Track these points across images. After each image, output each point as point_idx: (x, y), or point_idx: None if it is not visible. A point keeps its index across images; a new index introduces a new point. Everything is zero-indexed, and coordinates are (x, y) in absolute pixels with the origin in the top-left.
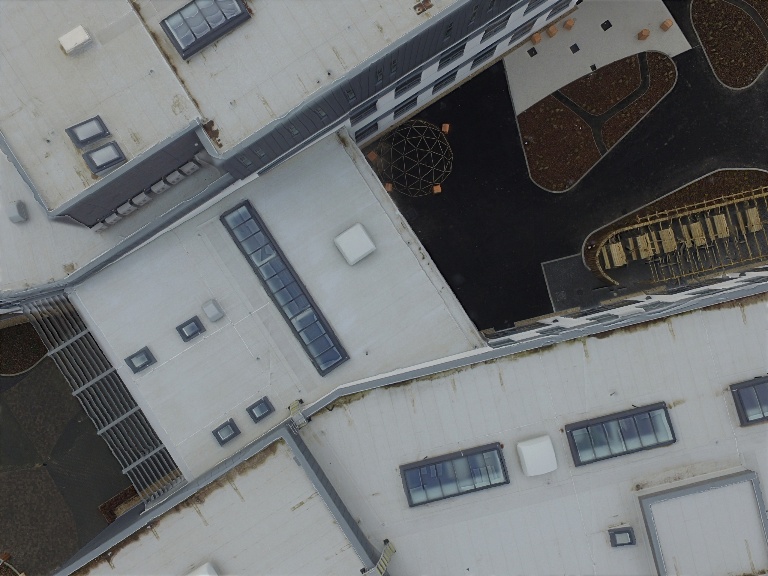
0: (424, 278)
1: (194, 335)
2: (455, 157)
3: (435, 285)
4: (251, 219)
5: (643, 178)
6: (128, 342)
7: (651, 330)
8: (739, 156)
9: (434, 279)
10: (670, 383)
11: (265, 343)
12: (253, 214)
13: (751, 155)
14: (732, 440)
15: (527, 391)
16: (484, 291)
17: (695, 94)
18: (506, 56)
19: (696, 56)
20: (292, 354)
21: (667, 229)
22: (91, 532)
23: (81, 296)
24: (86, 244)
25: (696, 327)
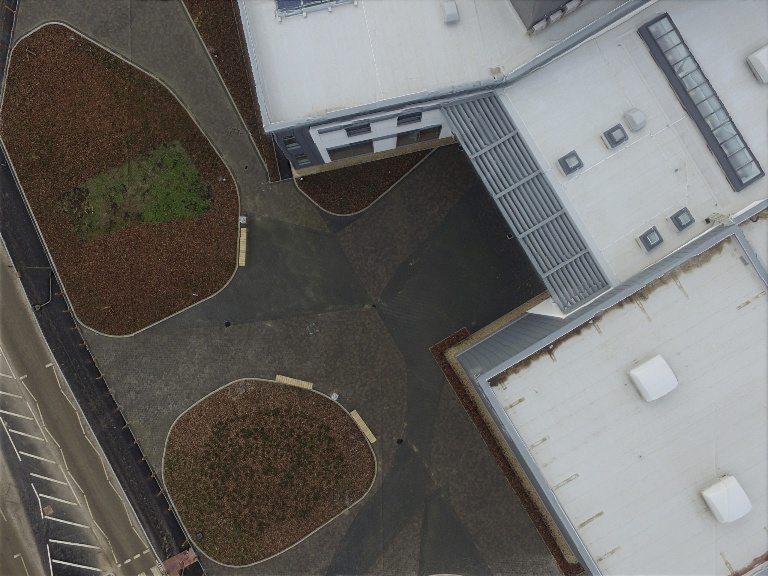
0: None
1: (620, 142)
2: None
3: None
4: (673, 31)
5: None
6: (555, 146)
7: None
8: None
9: None
10: None
11: (682, 156)
12: (674, 26)
13: None
14: None
15: None
16: None
17: None
18: None
19: None
20: (707, 169)
21: None
22: (420, 373)
23: (511, 98)
24: (514, 48)
25: None
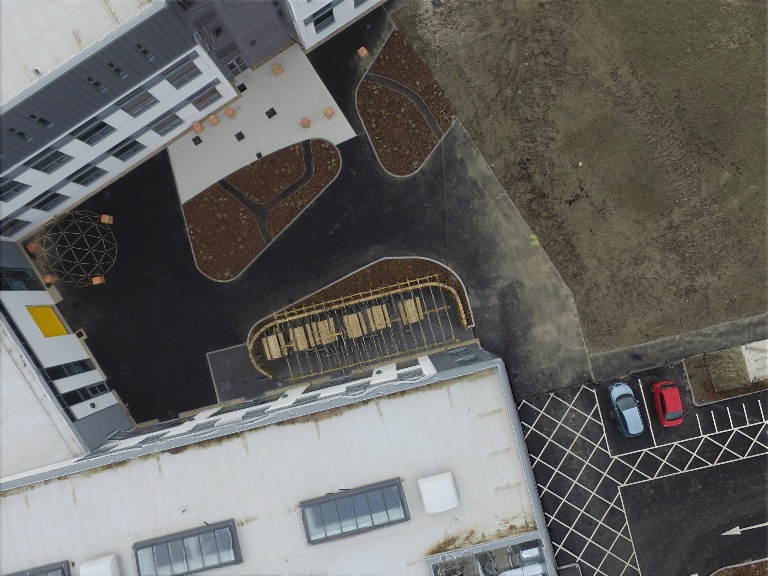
0: (23, 386)
1: None
2: (119, 247)
3: (36, 393)
4: None
5: (309, 267)
6: None
7: (225, 445)
8: (404, 244)
9: (35, 387)
10: (243, 499)
11: None
12: None
13: (416, 243)
14: (302, 558)
15: (100, 508)
16: (148, 382)
17: (360, 182)
18: (170, 145)
19: (361, 143)
20: None
21: (324, 320)
22: None
23: None
24: None
25: (270, 442)
